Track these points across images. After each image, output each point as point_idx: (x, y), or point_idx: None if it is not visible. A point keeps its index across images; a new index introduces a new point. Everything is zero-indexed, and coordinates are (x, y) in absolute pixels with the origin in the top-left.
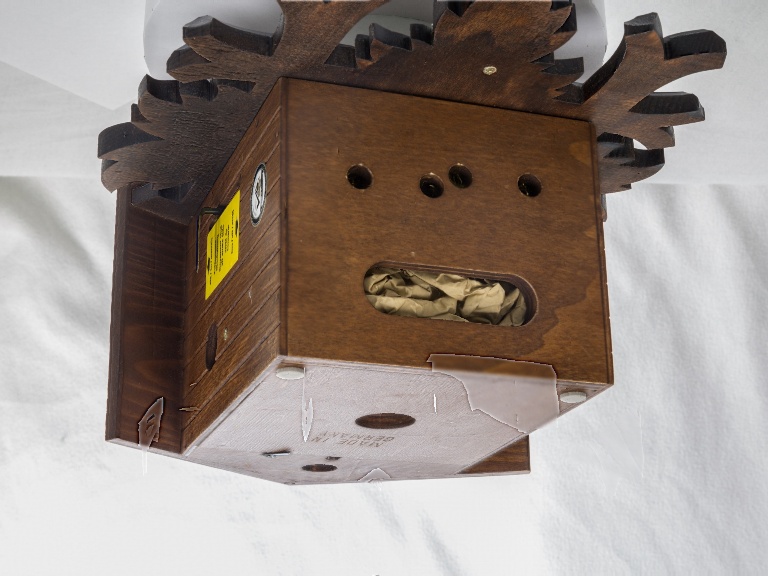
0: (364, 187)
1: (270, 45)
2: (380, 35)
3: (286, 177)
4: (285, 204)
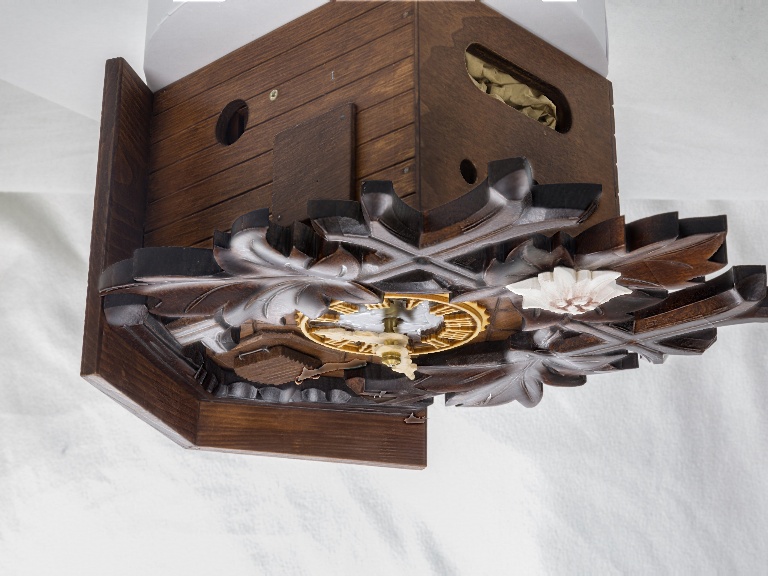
0: None
1: None
2: None
3: None
4: (616, 201)
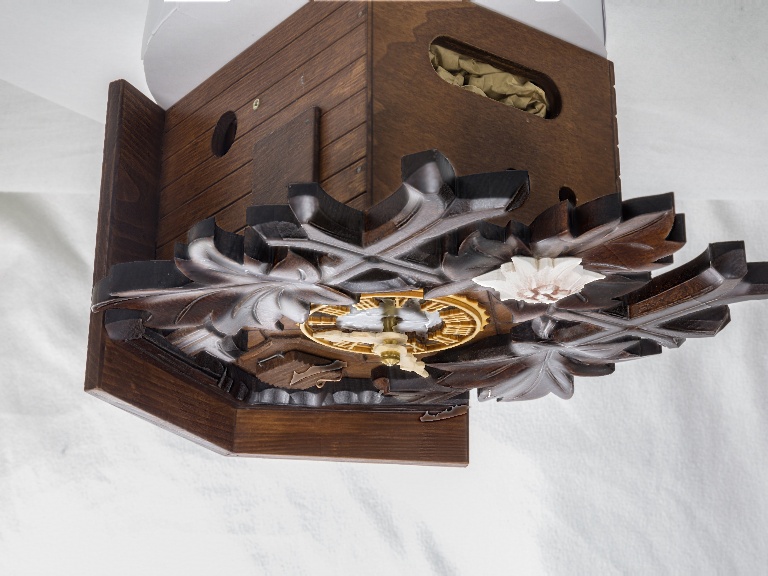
0: None
1: None
2: None
3: None
4: (617, 183)
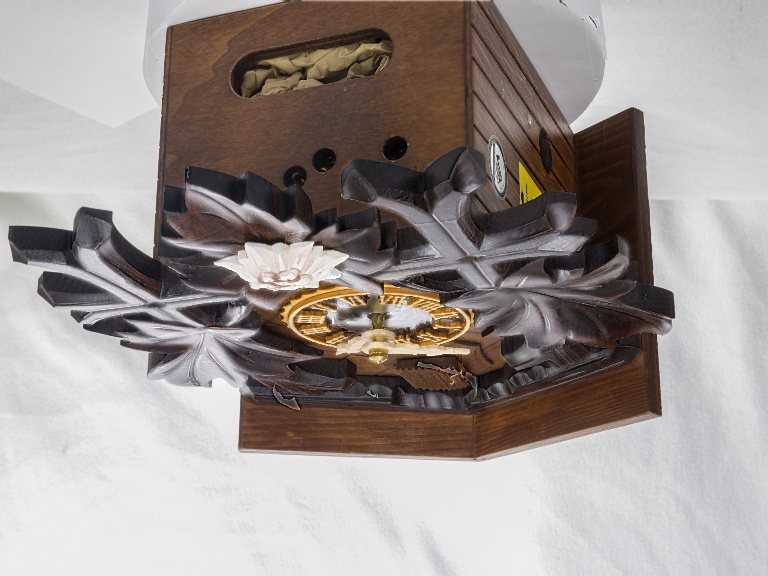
0: (391, 154)
1: (486, 225)
2: (369, 215)
3: (468, 127)
4: (468, 101)
